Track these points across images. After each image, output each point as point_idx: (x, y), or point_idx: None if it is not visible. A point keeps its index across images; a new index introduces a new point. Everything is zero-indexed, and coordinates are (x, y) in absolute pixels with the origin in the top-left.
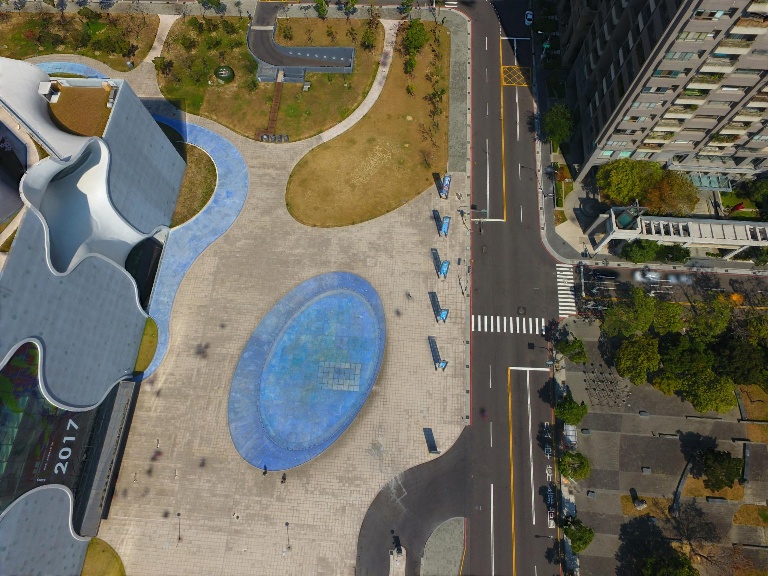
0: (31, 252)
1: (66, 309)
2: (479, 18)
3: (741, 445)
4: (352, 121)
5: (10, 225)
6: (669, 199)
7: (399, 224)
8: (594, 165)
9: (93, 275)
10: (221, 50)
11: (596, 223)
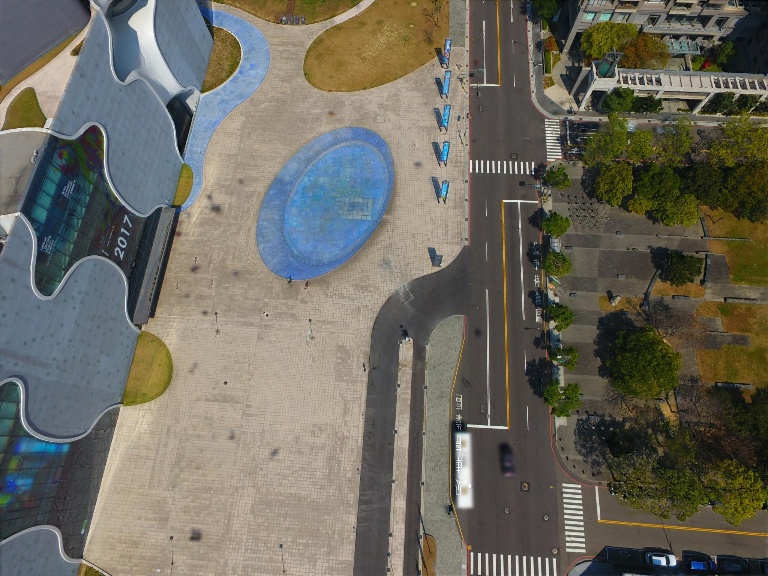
0: (99, 50)
1: (123, 116)
2: None
3: (704, 256)
4: (362, 7)
5: (78, 36)
6: (643, 53)
7: (405, 89)
8: (578, 32)
9: (143, 99)
10: None
11: (580, 79)
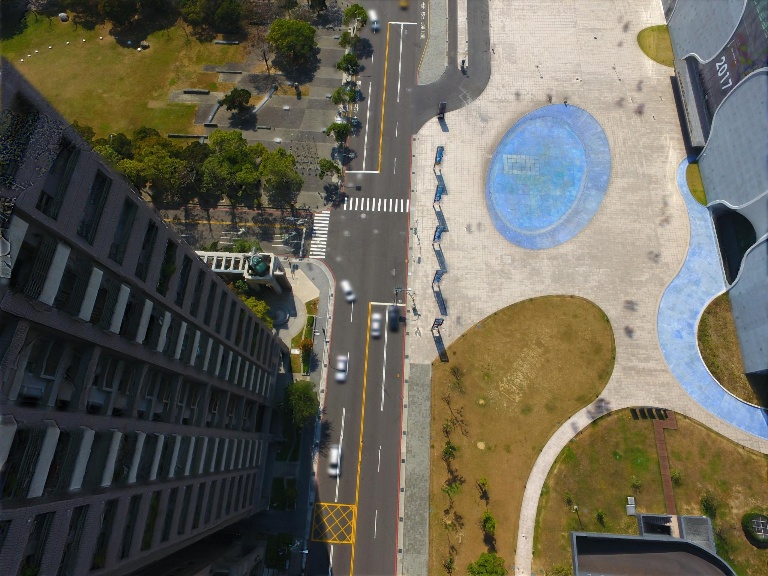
0: None
1: None
2: None
3: None
4: (556, 442)
5: None
6: None
7: (482, 299)
8: None
9: None
10: None
11: None
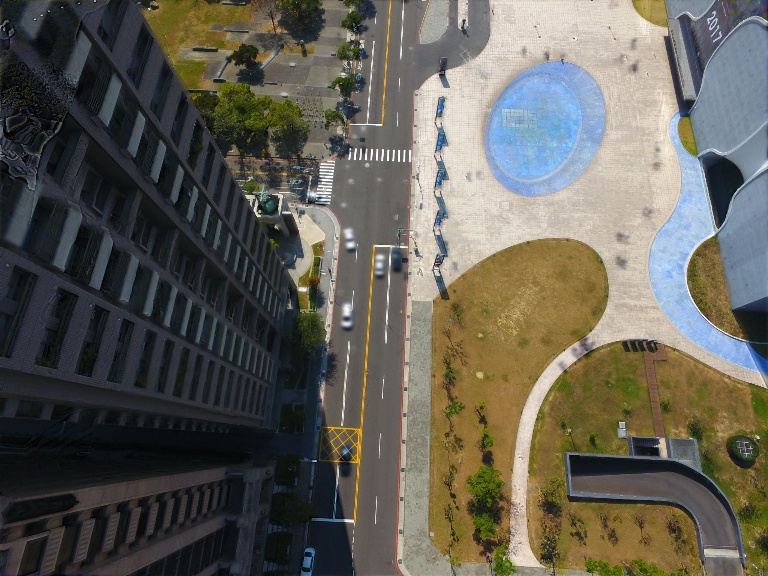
0: None
1: None
2: (384, 568)
3: None
4: (551, 372)
5: None
6: None
7: (482, 242)
8: None
9: None
10: (767, 504)
11: None
